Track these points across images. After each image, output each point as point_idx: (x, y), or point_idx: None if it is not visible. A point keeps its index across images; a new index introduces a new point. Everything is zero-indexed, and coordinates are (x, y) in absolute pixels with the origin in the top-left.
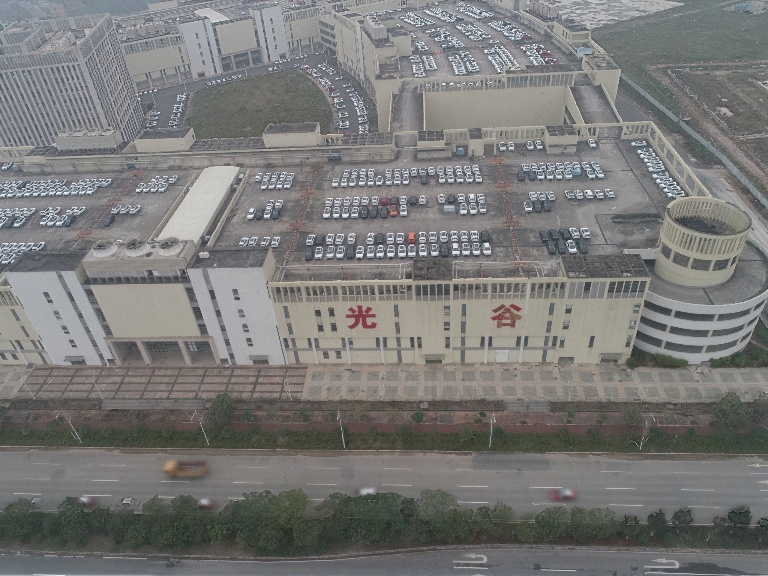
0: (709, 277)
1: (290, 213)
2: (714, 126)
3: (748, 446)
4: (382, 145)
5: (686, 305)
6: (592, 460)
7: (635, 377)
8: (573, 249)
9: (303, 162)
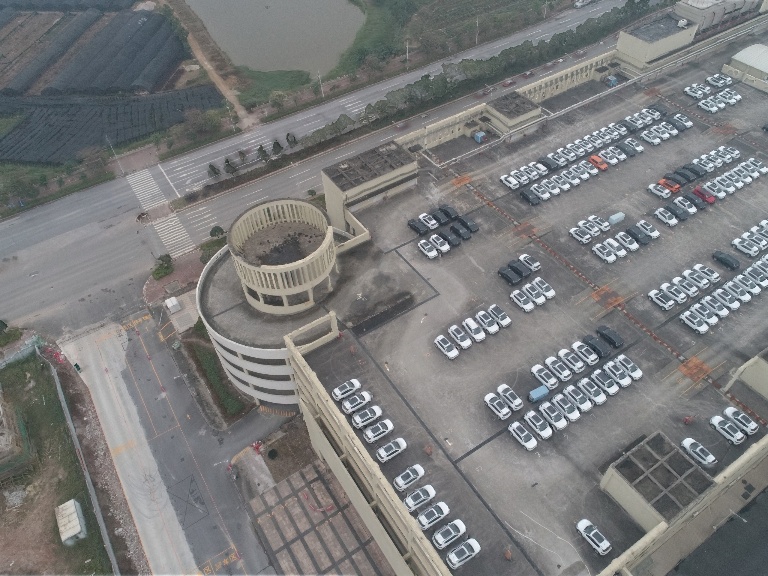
0: None
1: (767, 140)
2: None
3: (225, 240)
4: None
5: None
6: None
7: None
8: (423, 215)
9: None
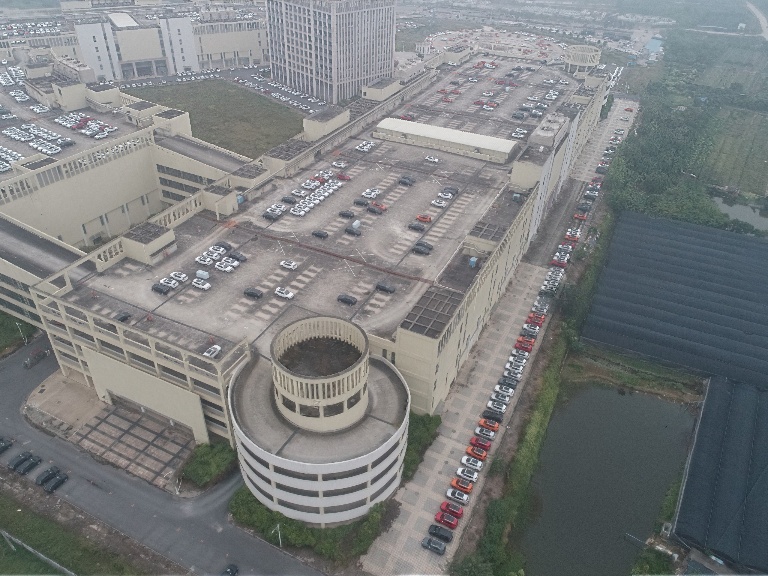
0: None
1: None
2: None
3: None
4: None
5: None
6: None
7: None
8: None
9: None
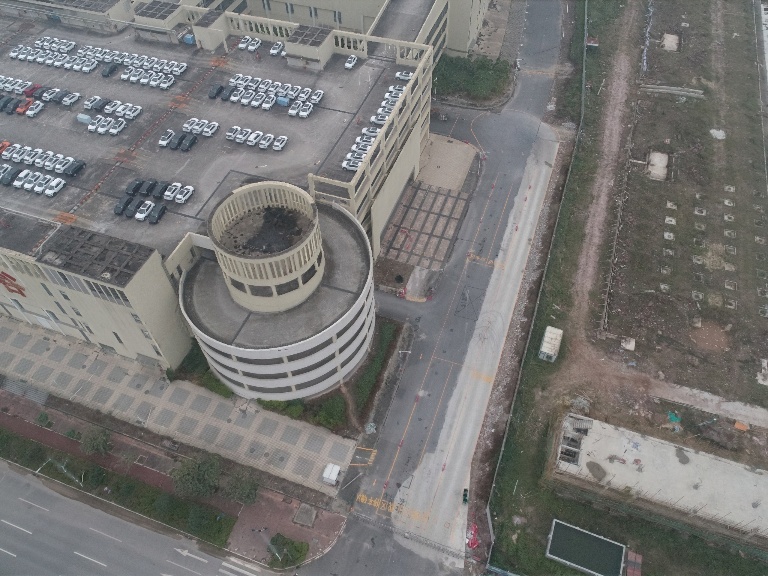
0: (252, 301)
1: None
2: (629, 62)
3: None
4: (93, 12)
5: (197, 331)
6: (25, 481)
7: (167, 392)
8: (140, 214)
9: (22, 15)
